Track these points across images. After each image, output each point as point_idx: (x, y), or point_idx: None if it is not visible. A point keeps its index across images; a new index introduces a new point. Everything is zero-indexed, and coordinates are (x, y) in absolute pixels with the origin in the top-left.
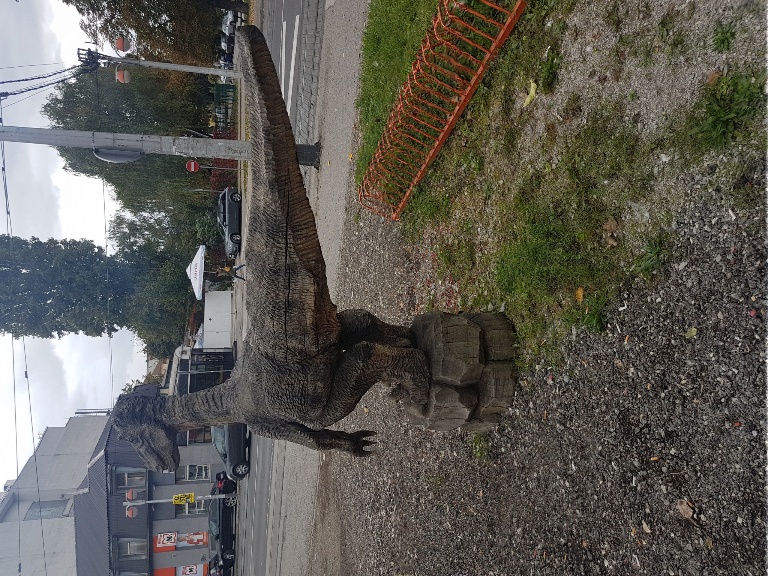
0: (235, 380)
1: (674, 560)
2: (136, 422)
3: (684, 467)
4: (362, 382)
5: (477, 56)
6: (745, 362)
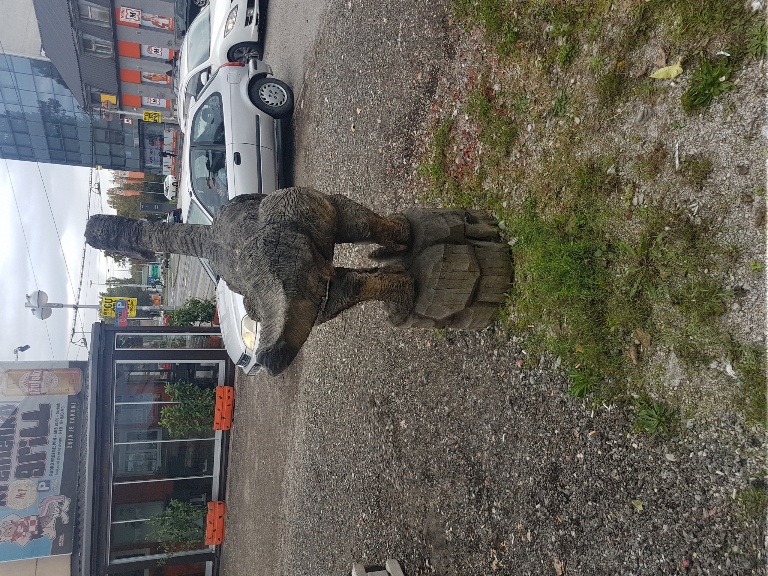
0: (217, 240)
1: (535, 570)
2: (111, 246)
3: (573, 551)
4: (345, 306)
5: None
6: (655, 573)
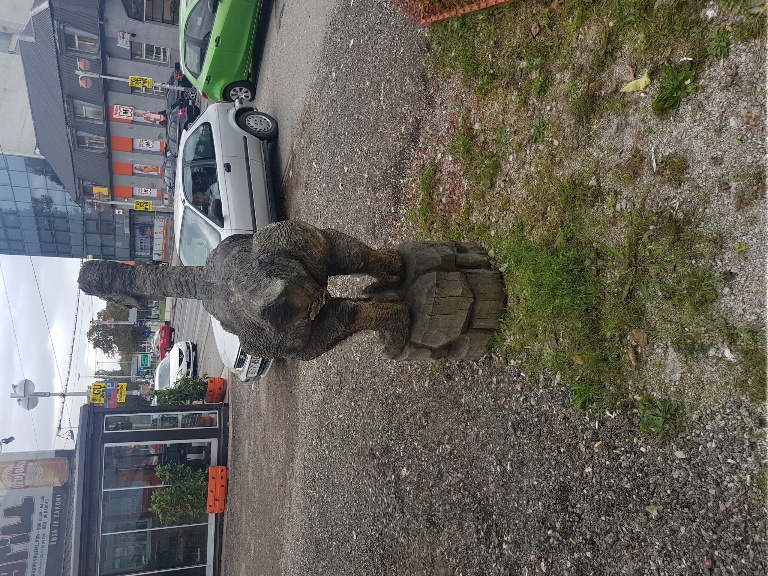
0: (211, 279)
1: None
2: (106, 291)
3: (591, 573)
4: (341, 337)
5: None
6: None
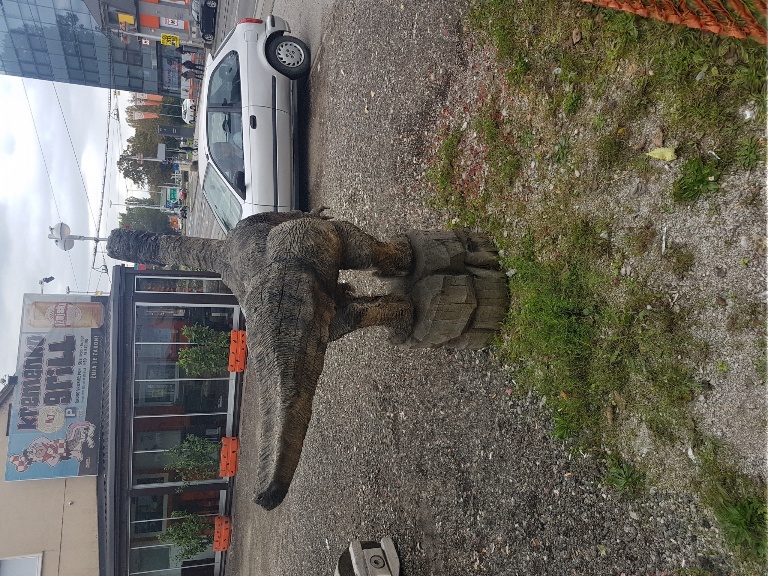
0: (227, 261)
1: None
2: (127, 260)
3: (544, 573)
4: None
5: (648, 6)
6: None
